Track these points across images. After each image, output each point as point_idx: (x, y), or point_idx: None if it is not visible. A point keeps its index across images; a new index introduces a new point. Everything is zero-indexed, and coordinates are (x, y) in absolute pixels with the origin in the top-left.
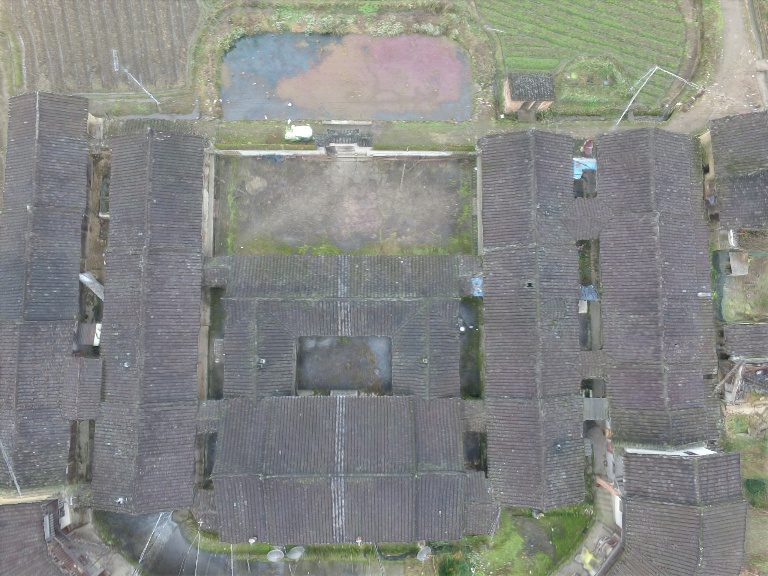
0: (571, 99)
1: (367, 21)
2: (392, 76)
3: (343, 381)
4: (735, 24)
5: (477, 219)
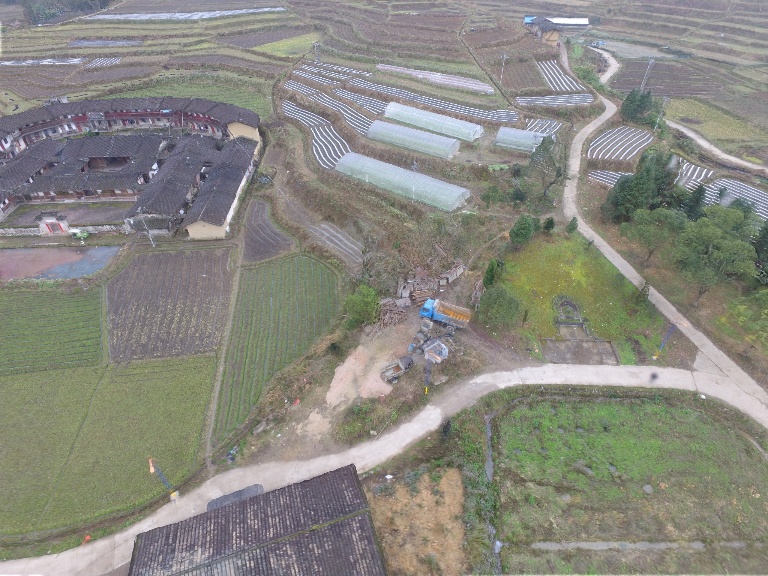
0: None
1: (0, 282)
2: (7, 265)
3: None
4: None
5: (8, 215)
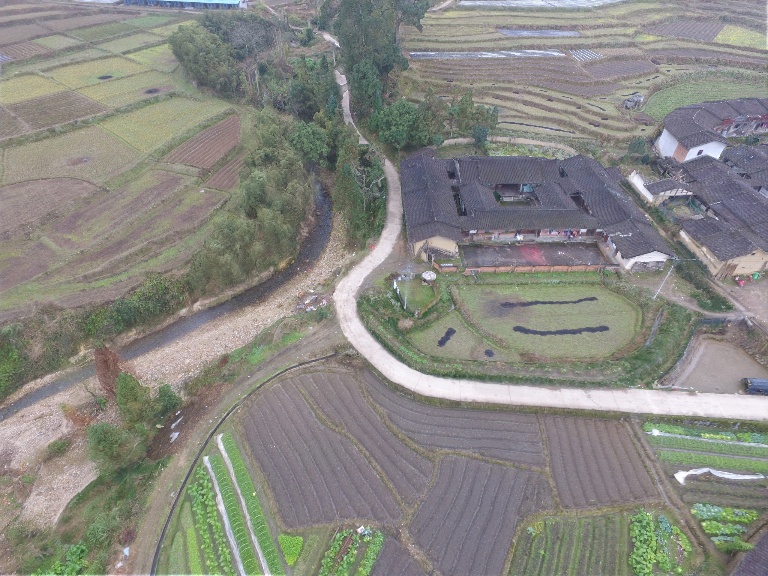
0: None
1: None
2: None
3: None
4: None
5: None
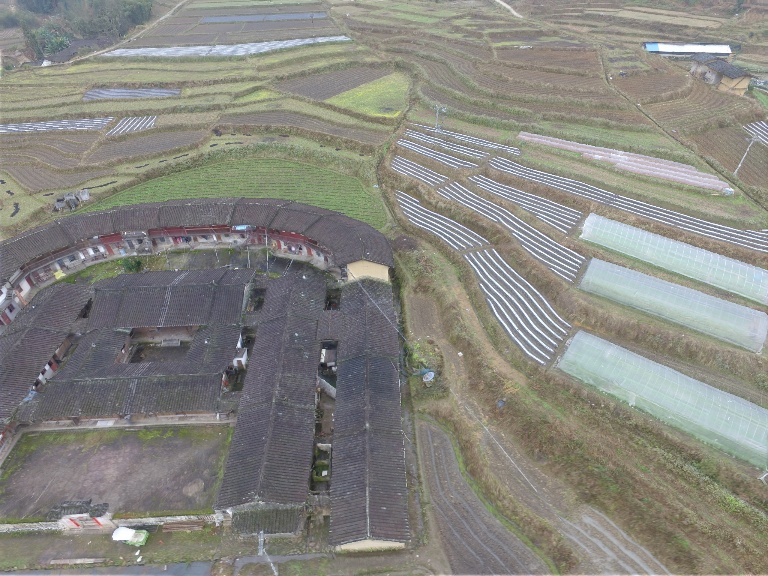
0: None
1: None
2: None
3: (169, 351)
4: None
5: (2, 465)
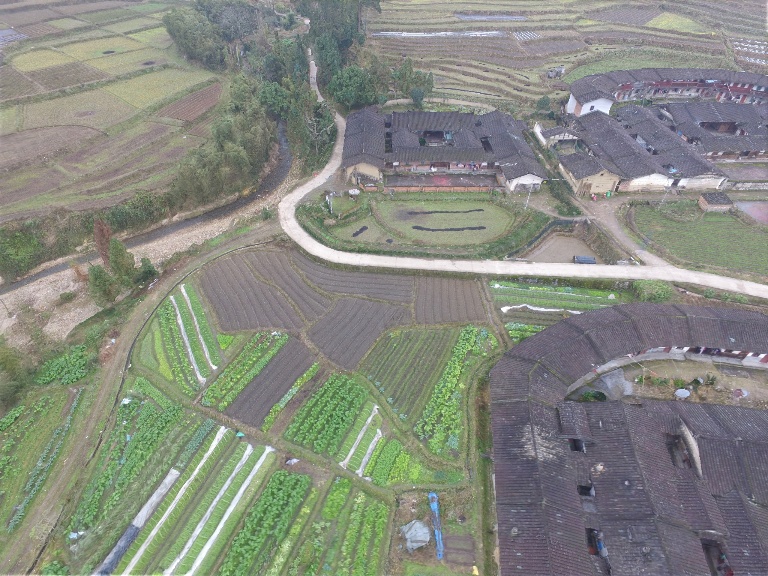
0: (688, 205)
1: None
2: None
3: None
4: (617, 231)
5: None
